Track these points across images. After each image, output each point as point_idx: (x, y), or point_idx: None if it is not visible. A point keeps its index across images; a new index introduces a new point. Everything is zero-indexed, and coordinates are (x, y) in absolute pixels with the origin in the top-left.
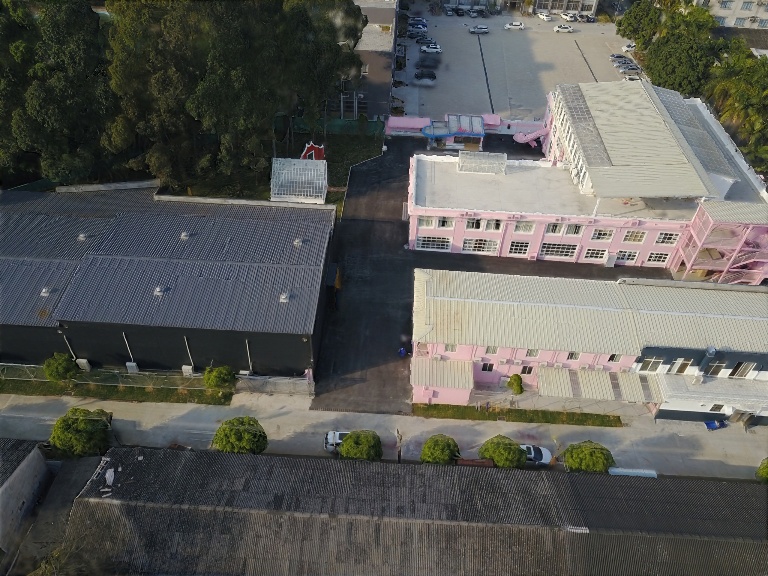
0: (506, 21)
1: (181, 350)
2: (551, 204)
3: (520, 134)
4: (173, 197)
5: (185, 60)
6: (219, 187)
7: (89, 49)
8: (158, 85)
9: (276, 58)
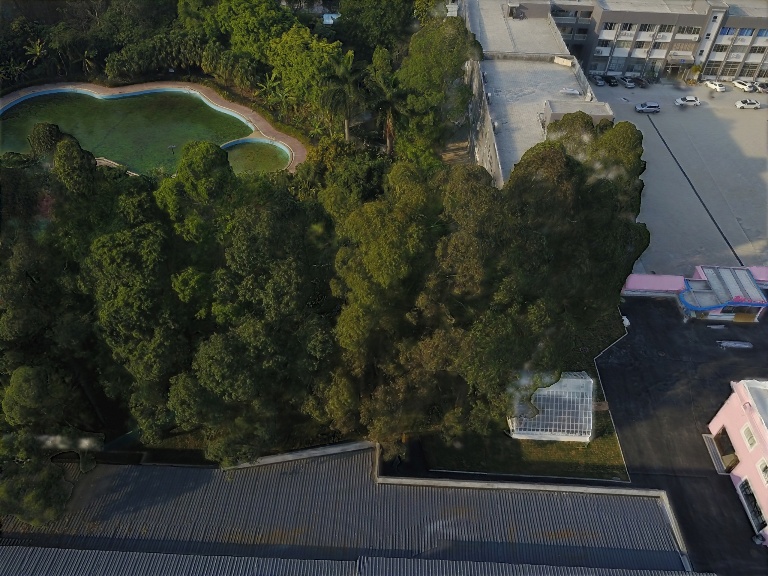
0: (671, 93)
1: None
2: None
3: None
4: (407, 480)
5: None
6: (426, 408)
7: (301, 278)
8: (435, 355)
9: (587, 275)
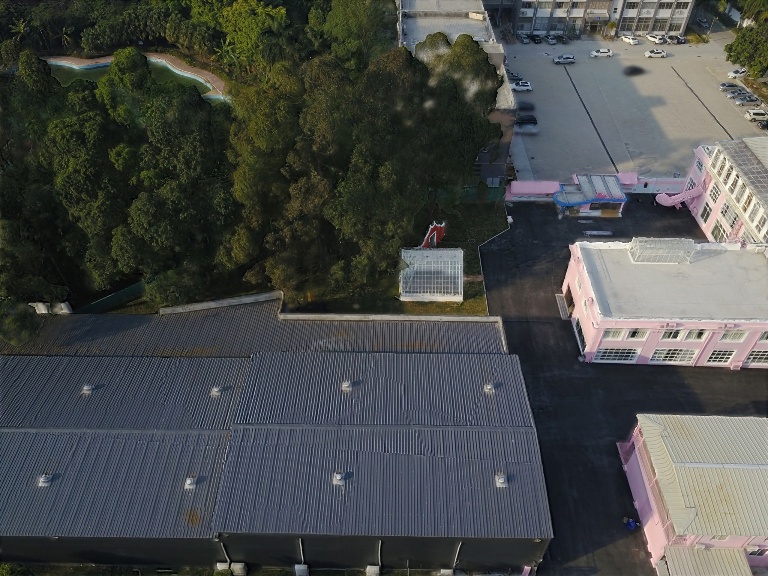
0: (589, 47)
1: (370, 552)
2: (761, 304)
3: (663, 195)
4: (302, 315)
5: (322, 157)
6: None
7: (205, 150)
8: (300, 196)
9: (428, 146)
